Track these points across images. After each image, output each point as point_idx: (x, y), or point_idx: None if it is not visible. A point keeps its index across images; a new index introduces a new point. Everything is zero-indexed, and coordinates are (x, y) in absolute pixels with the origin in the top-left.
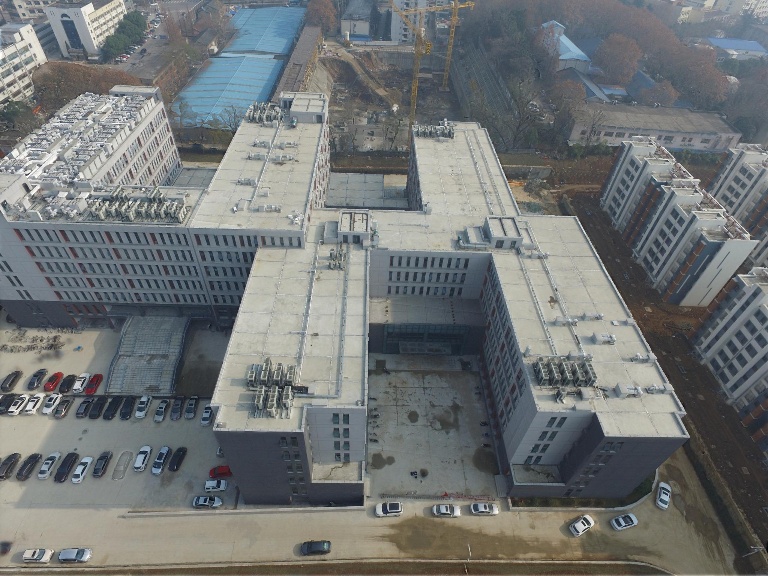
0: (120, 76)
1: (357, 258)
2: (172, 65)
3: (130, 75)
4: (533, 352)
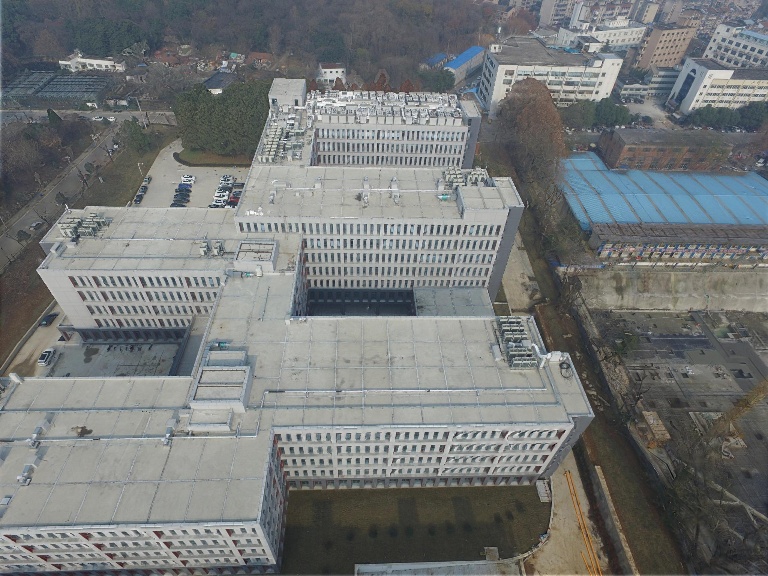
0: (542, 110)
1: (216, 265)
2: (684, 149)
3: (556, 115)
4: (21, 391)
